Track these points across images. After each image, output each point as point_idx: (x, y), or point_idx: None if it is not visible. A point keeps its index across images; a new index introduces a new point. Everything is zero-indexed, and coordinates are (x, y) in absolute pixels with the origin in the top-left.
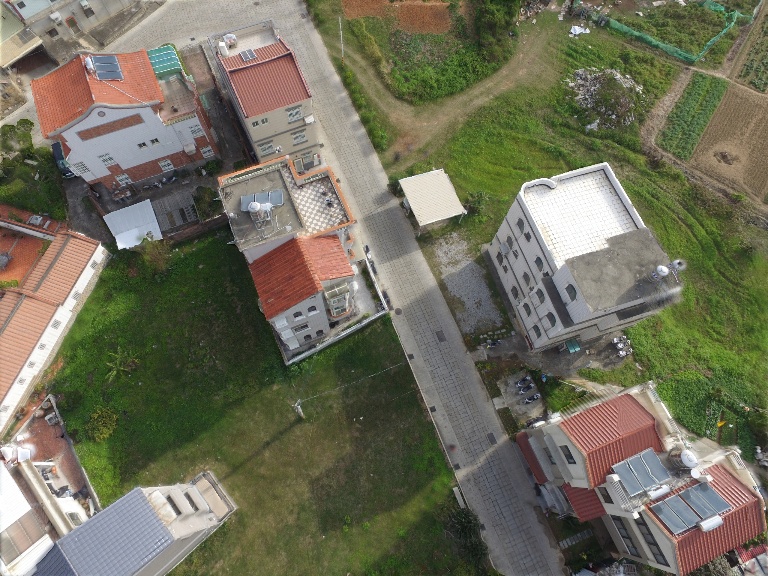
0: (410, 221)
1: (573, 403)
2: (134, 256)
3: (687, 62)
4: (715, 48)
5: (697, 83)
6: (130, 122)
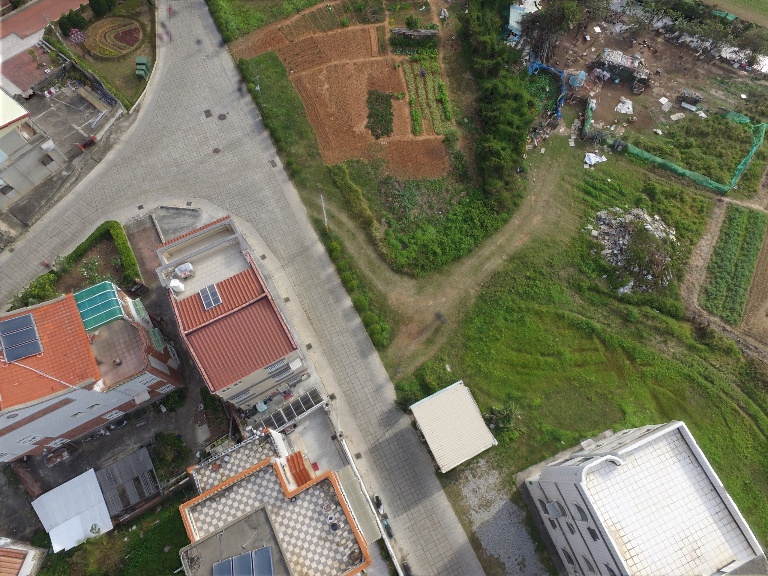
0: (426, 448)
1: None
2: (77, 548)
3: (719, 192)
4: (748, 173)
5: (734, 220)
6: (56, 407)
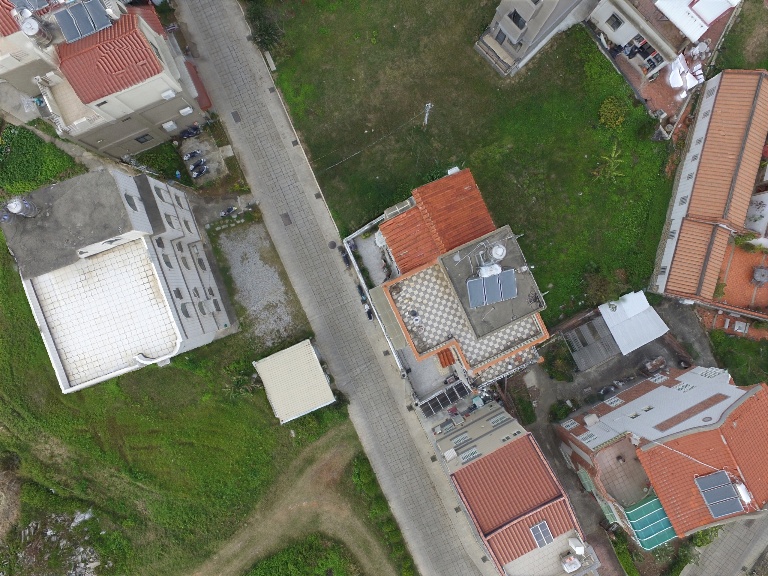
0: (322, 358)
1: (144, 77)
2: None
3: None
4: None
5: None
6: (670, 423)
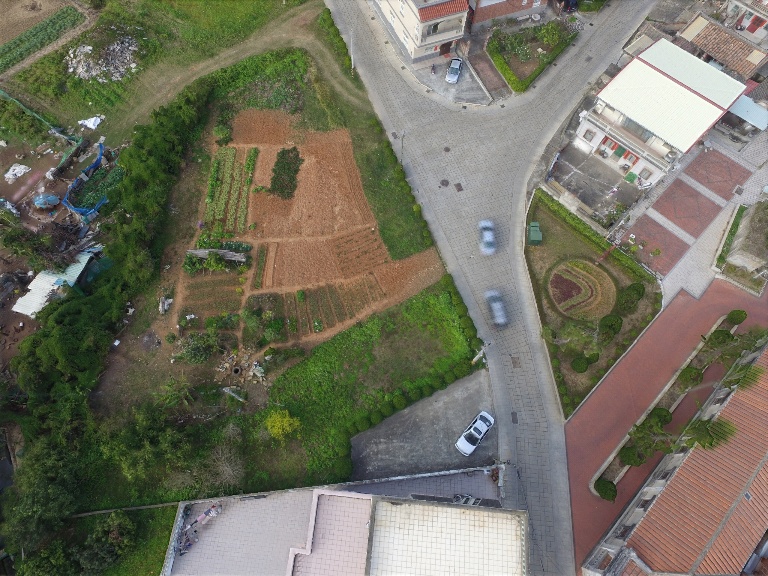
0: None
1: None
2: None
3: None
4: None
5: (5, 63)
6: None
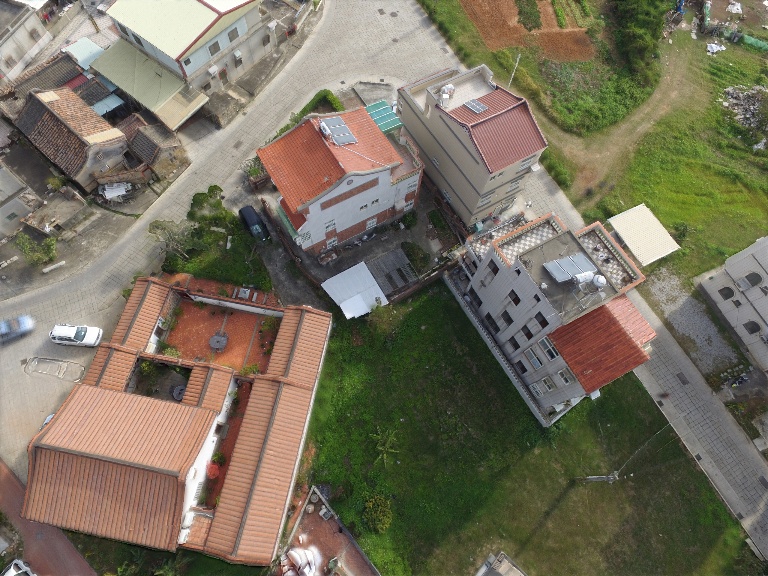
0: None
1: None
2: (355, 323)
3: None
4: None
5: None
6: (367, 186)
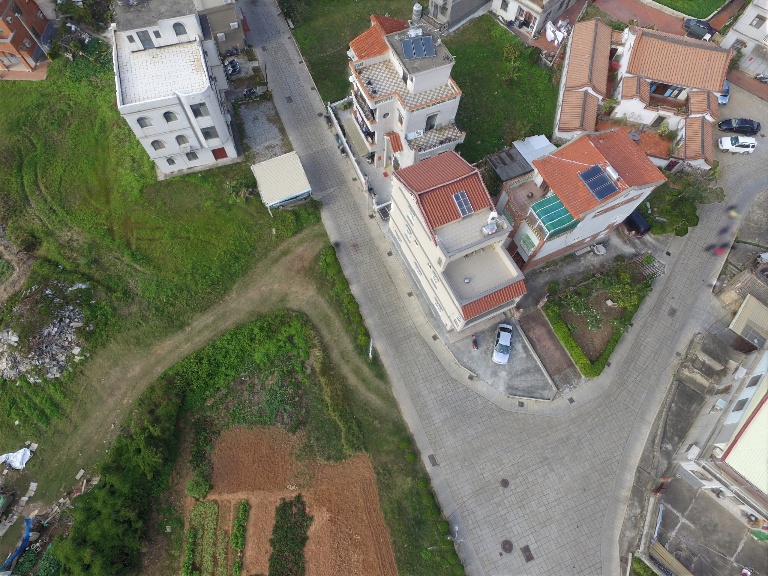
0: None
1: None
2: None
3: None
4: None
5: None
6: None
